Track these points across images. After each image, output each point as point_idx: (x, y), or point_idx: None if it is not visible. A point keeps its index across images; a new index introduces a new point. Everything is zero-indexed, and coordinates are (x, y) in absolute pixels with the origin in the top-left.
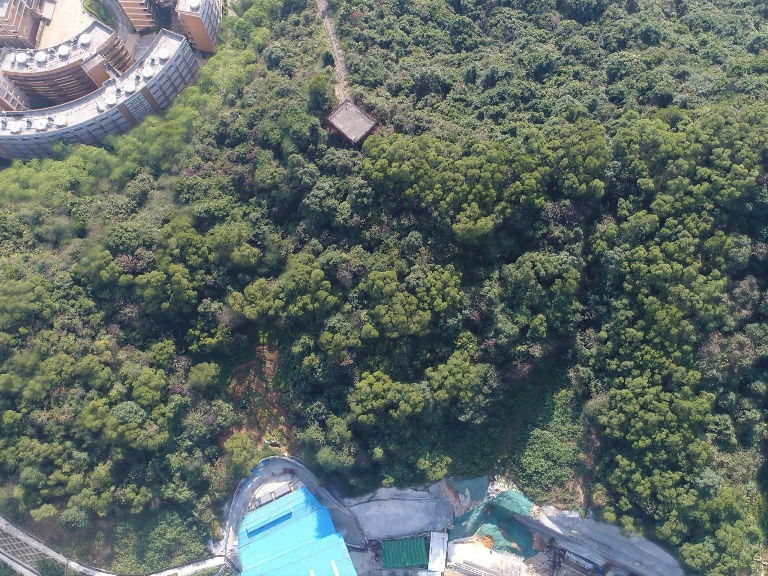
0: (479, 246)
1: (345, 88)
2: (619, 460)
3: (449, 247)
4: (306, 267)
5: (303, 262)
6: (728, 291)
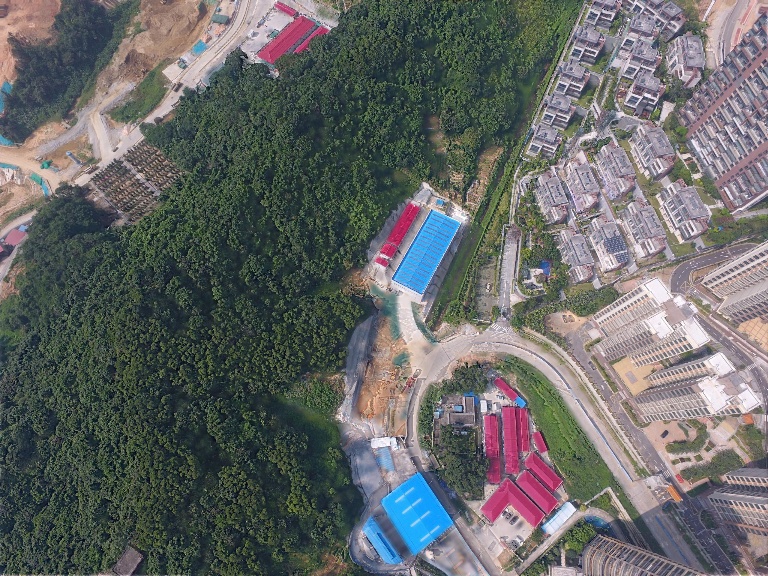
0: (206, 460)
1: (104, 574)
2: (312, 364)
3: (208, 478)
4: (229, 568)
5: (226, 571)
6: (220, 324)
